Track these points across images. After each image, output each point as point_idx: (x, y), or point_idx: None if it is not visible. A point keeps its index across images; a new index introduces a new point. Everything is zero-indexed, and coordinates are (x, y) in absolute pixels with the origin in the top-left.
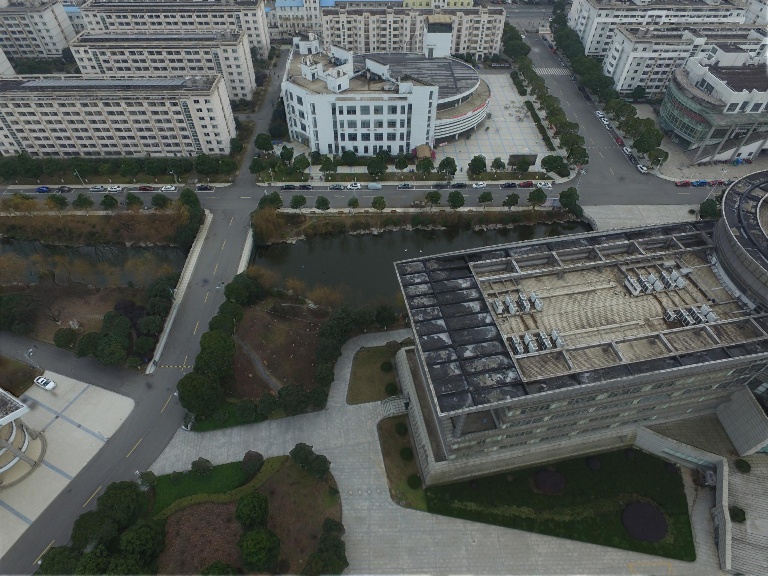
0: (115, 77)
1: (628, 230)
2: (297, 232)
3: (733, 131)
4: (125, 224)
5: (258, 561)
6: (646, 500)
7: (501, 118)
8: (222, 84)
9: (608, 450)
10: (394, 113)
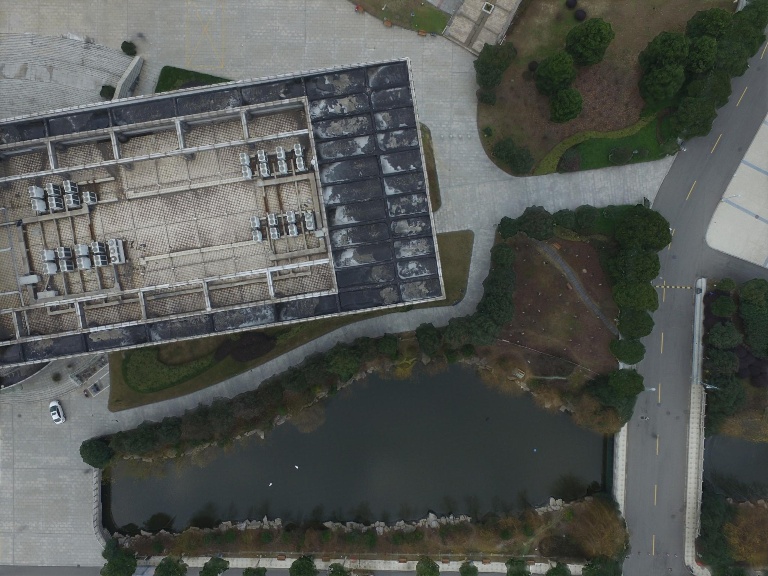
0: None
1: None
2: (550, 520)
3: None
4: None
5: None
6: None
7: None
8: None
9: None
10: None
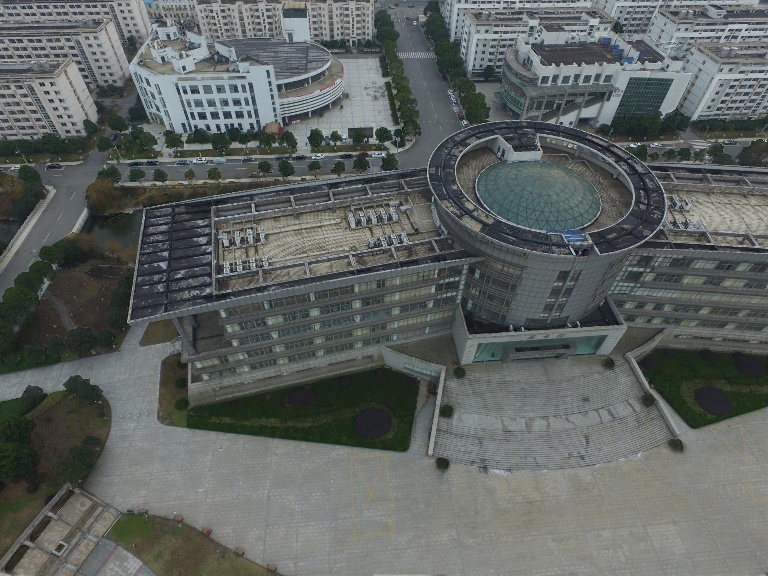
0: None
1: (365, 176)
2: (135, 203)
3: (554, 103)
4: None
5: (3, 468)
6: (380, 407)
7: (358, 97)
8: (73, 68)
9: (362, 370)
10: (236, 92)
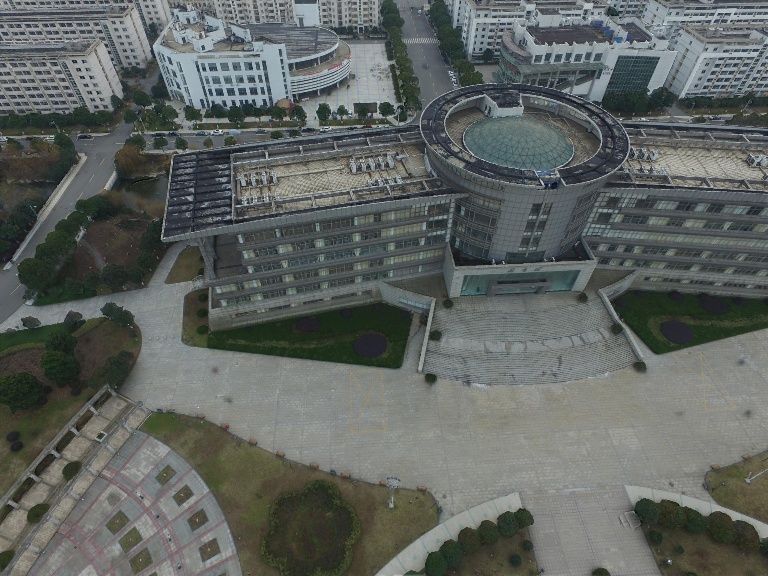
0: (5, 43)
1: (366, 131)
2: (158, 168)
3: (547, 81)
4: (4, 163)
5: (53, 369)
6: (377, 333)
7: (364, 78)
8: (102, 48)
9: (362, 305)
10: (251, 69)
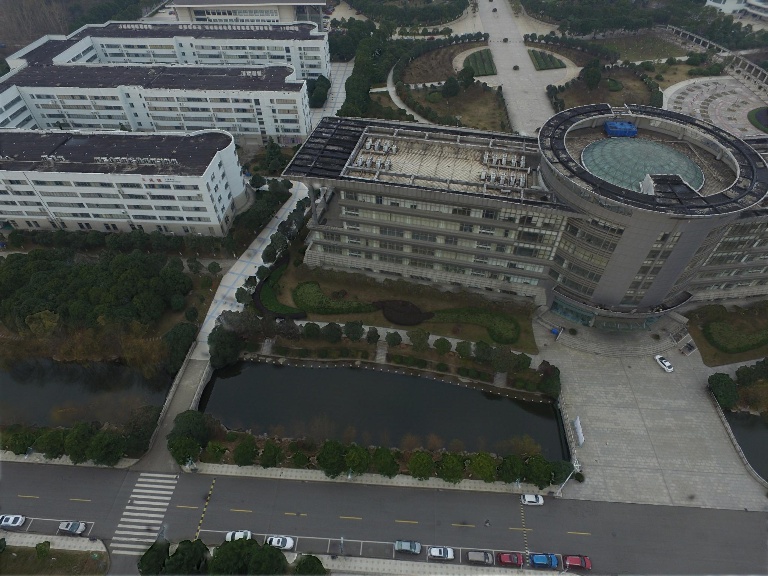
0: None
1: None
2: None
3: None
4: None
5: None
6: None
7: None
8: None
9: None
10: None
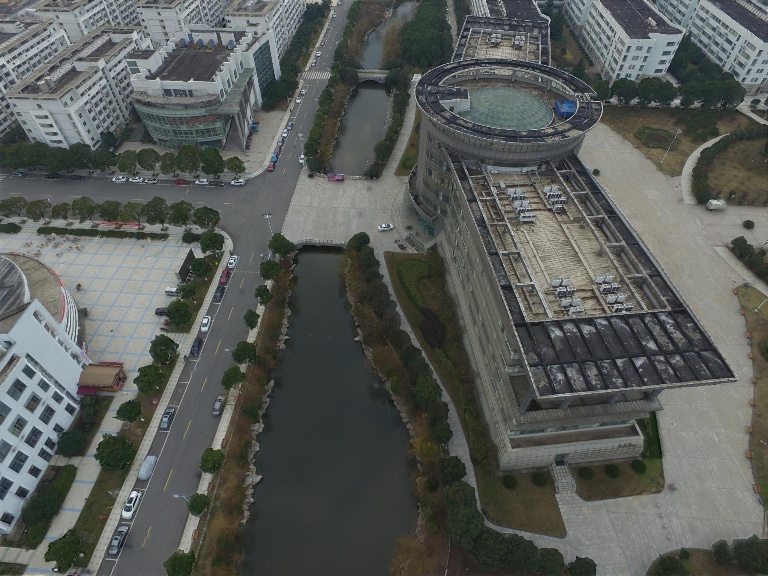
0: None
1: None
2: None
3: None
4: None
5: None
6: None
7: (59, 267)
8: None
9: None
10: (22, 389)
